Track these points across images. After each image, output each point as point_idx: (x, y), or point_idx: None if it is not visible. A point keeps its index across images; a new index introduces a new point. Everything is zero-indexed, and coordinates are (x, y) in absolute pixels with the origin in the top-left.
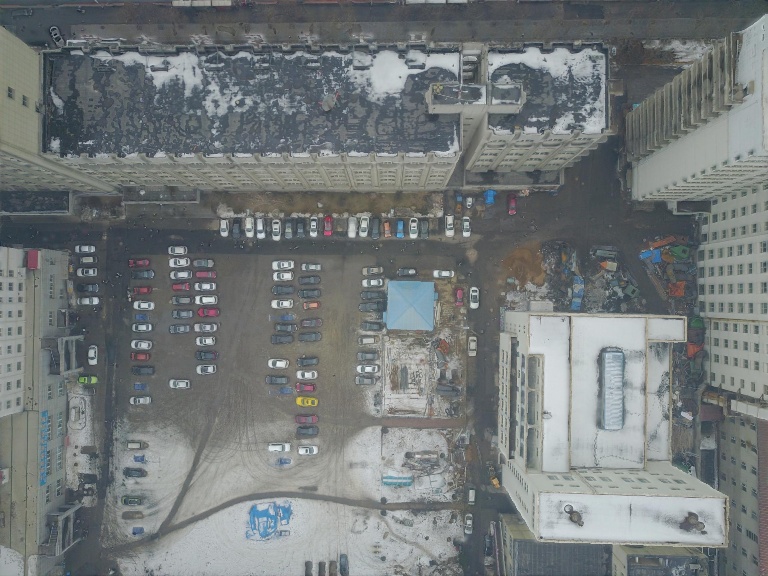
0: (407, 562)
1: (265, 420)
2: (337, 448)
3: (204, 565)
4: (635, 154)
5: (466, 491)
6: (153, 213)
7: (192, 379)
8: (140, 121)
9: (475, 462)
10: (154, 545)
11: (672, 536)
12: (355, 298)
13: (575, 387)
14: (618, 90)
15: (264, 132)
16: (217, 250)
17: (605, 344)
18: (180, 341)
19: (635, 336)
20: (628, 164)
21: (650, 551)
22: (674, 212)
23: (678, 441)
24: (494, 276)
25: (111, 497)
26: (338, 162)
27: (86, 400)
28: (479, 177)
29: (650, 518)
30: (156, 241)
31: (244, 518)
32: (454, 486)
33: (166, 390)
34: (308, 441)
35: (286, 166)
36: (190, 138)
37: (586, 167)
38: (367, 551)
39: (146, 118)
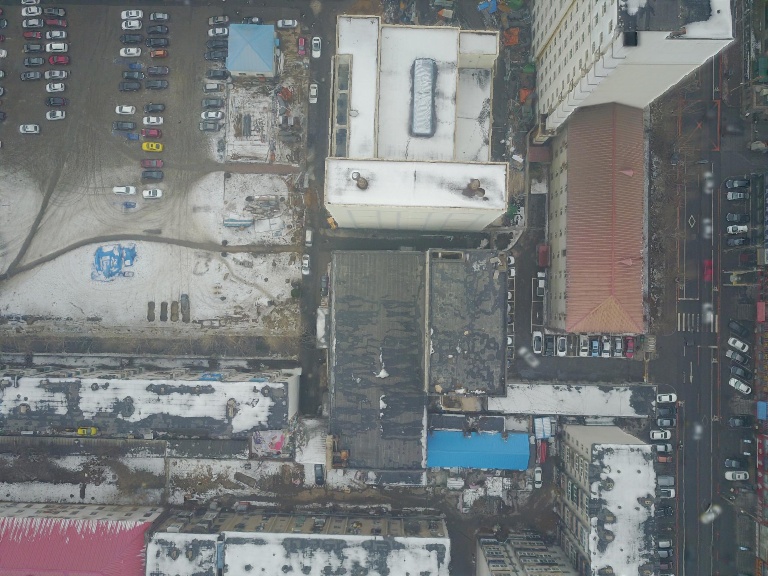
0: (246, 303)
1: (112, 165)
2: (181, 193)
3: (50, 305)
4: None
5: (304, 234)
6: None
7: (42, 125)
8: None
9: (314, 206)
10: (2, 285)
11: (454, 201)
12: (202, 48)
13: (388, 96)
14: None
15: None
16: (69, 1)
17: (418, 55)
18: (31, 89)
19: (448, 48)
20: None
21: None
22: None
23: (510, 185)
24: None
25: None
26: None
27: None
28: None
29: (434, 184)
30: None
31: (90, 260)
32: (293, 229)
33: (17, 136)
34: (153, 186)
35: None
36: None
37: None
38: (208, 292)
39: None
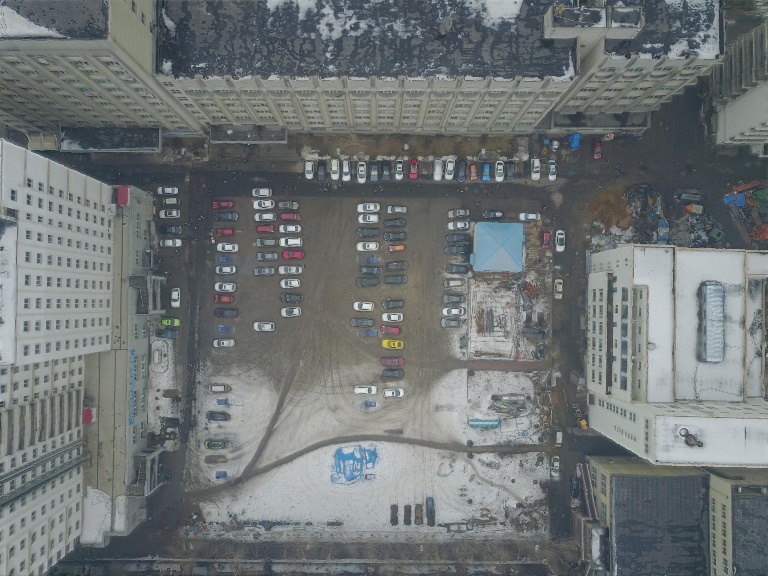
0: (493, 505)
1: (350, 363)
2: (423, 391)
3: (288, 509)
4: (725, 95)
5: (552, 433)
6: (237, 155)
7: (276, 322)
8: (253, 44)
9: (561, 405)
10: (237, 489)
11: None
12: (440, 241)
13: None
14: (731, 17)
15: (379, 56)
16: (301, 193)
17: (704, 278)
18: (264, 284)
19: (734, 270)
20: (712, 109)
21: (752, 482)
22: (761, 154)
23: (763, 383)
24: (579, 219)
25: (193, 441)
26: (448, 90)
27: (168, 343)
28: (567, 119)
29: (765, 441)
30: (239, 183)
31: (329, 462)
32: (540, 428)
33: (250, 333)
34: (393, 384)
35: (394, 94)
36: (304, 62)
37: (670, 112)
38: (453, 494)
39: (260, 41)
